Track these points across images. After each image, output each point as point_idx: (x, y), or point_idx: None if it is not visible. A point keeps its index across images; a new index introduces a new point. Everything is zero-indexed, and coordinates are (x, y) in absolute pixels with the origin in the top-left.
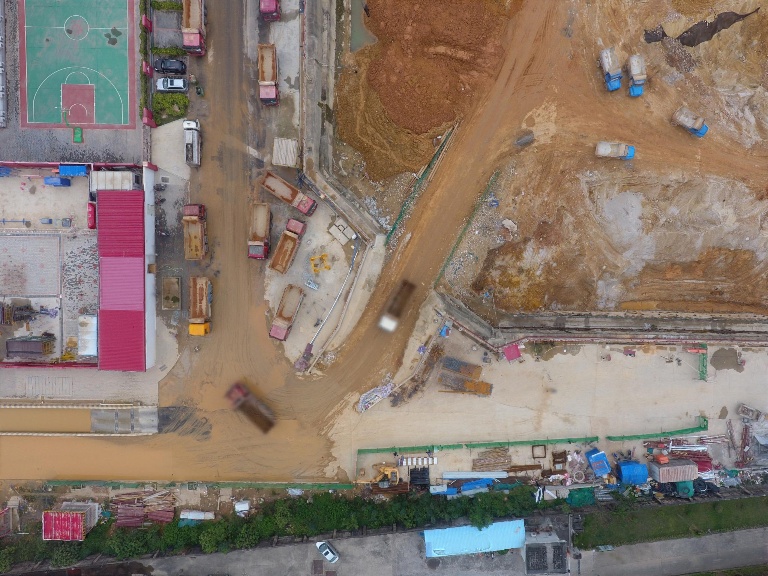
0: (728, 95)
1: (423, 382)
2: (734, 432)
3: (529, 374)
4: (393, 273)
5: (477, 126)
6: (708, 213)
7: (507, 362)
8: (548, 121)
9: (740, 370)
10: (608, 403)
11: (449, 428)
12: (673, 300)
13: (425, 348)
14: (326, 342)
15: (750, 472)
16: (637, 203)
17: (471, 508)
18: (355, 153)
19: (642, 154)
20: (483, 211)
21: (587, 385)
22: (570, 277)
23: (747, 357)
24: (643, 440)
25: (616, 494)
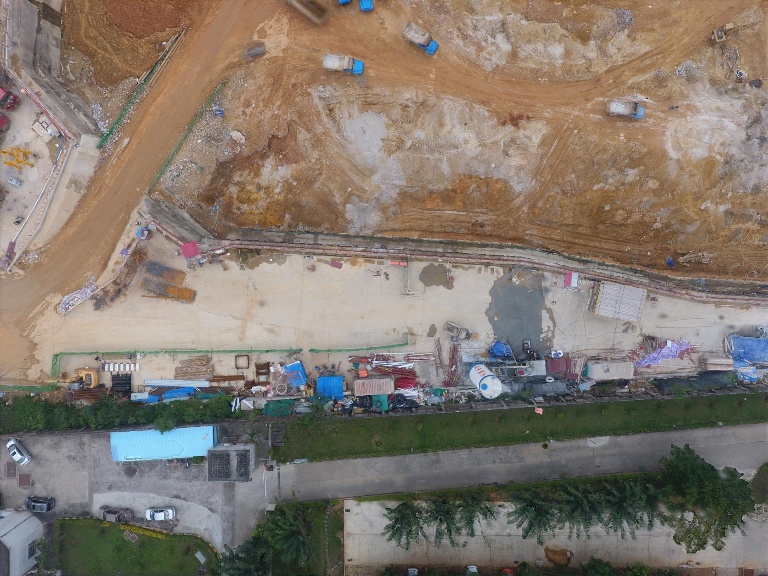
0: (476, 19)
1: (125, 286)
2: (443, 351)
3: (234, 282)
4: (107, 177)
5: (205, 34)
6: (451, 137)
7: (211, 269)
8: (280, 33)
9: (450, 287)
10: (314, 315)
11: (152, 334)
12: (434, 231)
13: (128, 251)
14: (28, 241)
15: (455, 391)
16: (379, 123)
17: (160, 413)
18: (83, 58)
19: (376, 71)
20: (207, 120)
21: (293, 296)
22: (306, 195)
23: (457, 274)
24: (349, 355)
25: (315, 407)
